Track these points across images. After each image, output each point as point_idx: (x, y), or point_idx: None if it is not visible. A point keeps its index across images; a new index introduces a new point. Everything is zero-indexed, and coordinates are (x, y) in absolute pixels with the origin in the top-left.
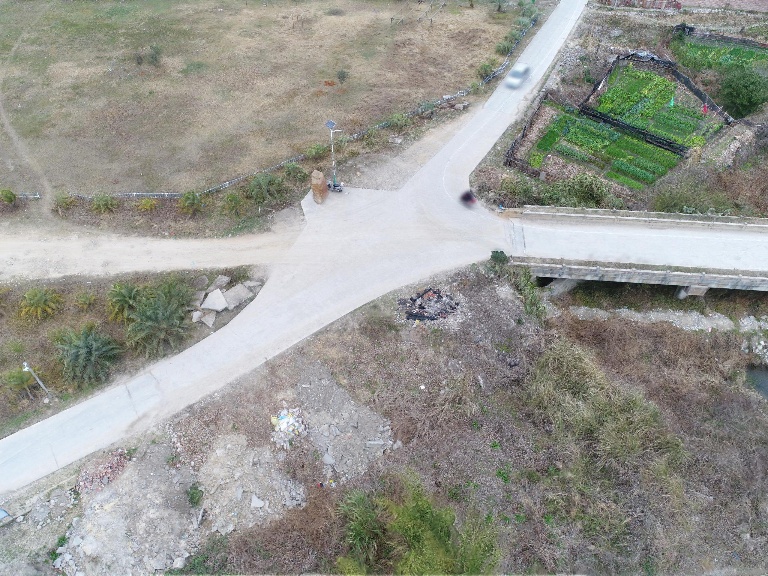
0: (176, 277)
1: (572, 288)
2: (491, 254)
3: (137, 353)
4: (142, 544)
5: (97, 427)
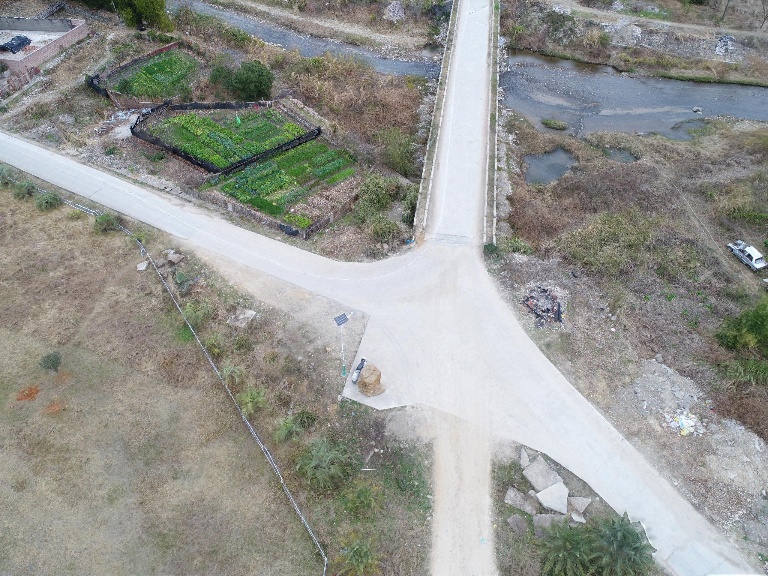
0: None
1: None
2: None
3: None
4: None
5: None
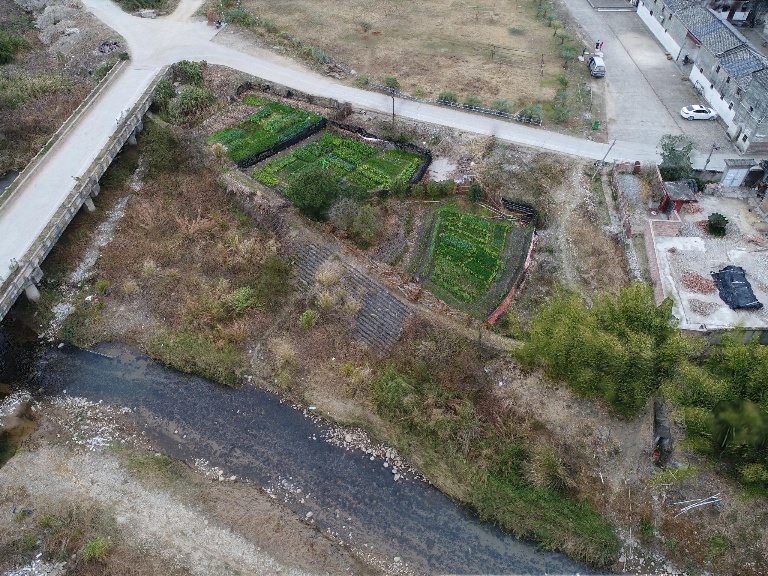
0: (169, 4)
1: None
2: None
3: None
4: None
5: None
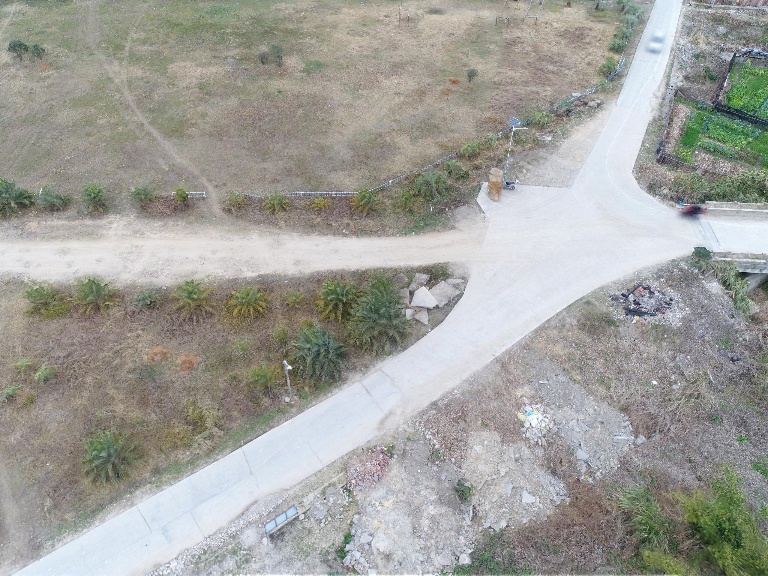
0: (375, 275)
1: (761, 283)
2: (690, 250)
3: (363, 351)
4: (428, 541)
5: (348, 425)
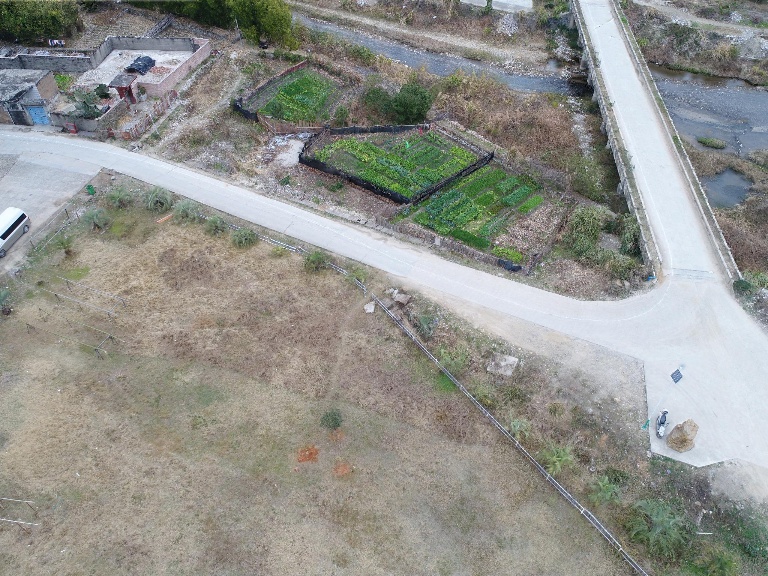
0: None
1: None
2: None
3: None
4: None
5: None
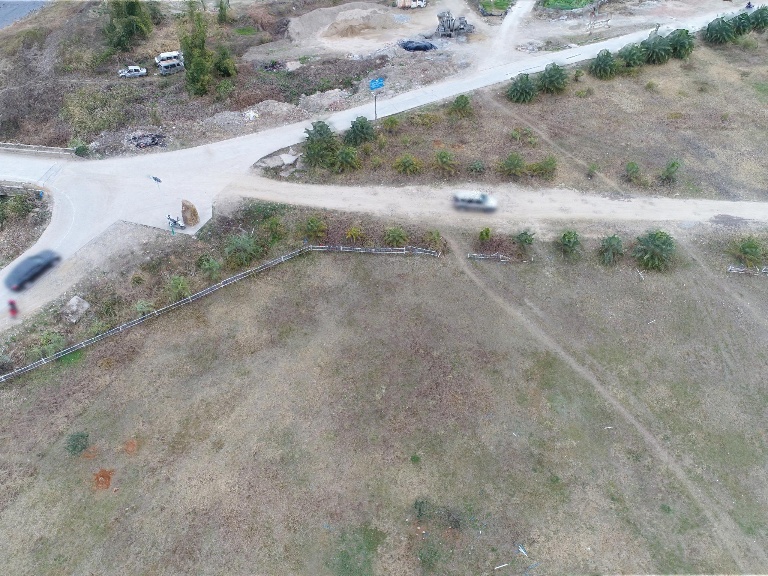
0: None
1: None
2: None
3: None
4: None
5: None
